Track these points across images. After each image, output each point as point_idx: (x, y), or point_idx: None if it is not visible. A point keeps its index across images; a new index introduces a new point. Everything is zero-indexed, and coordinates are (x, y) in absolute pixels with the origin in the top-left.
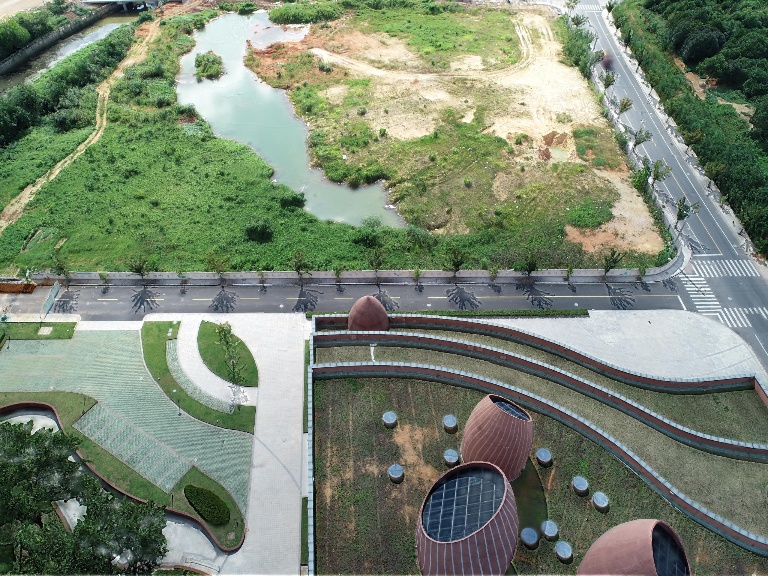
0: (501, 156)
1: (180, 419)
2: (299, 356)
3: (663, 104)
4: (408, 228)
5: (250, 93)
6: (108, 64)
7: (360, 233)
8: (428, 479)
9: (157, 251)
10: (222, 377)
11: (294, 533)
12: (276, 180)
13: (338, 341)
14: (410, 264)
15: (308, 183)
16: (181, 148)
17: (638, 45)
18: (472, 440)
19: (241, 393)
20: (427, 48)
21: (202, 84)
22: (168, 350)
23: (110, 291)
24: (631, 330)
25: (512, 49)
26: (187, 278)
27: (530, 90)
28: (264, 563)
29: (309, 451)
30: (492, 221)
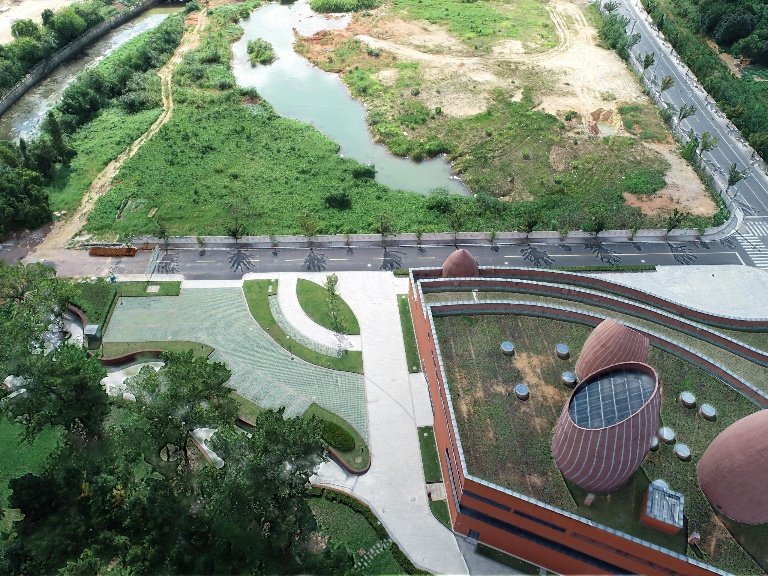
0: (553, 131)
1: (294, 363)
2: (393, 308)
3: (700, 83)
4: (477, 195)
5: (304, 77)
6: (165, 51)
7: (434, 200)
8: (551, 396)
9: (245, 218)
10: (326, 327)
11: (415, 457)
12: (343, 155)
13: (442, 287)
14: (484, 227)
15: (374, 157)
16: (250, 126)
17: (671, 29)
18: (594, 358)
19: (346, 340)
20: (468, 34)
21: (256, 69)
22: (271, 304)
23: (207, 254)
24: (697, 282)
25: (550, 34)
26: (277, 242)
27: (572, 71)
28: (392, 482)
29: (442, 374)
30: (554, 189)
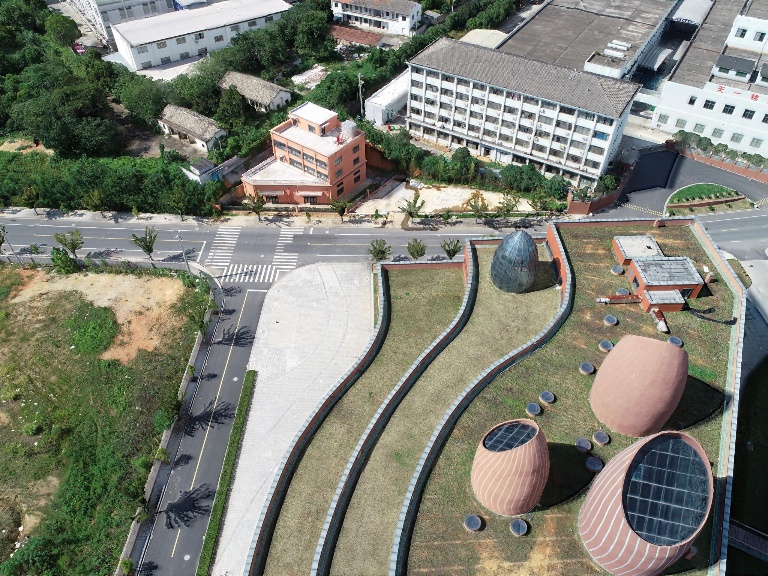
0: None
1: None
2: None
3: None
4: (7, 573)
5: None
6: None
7: None
8: (548, 558)
9: None
10: None
11: None
12: None
13: None
14: None
15: None
16: None
17: None
18: (533, 488)
19: None
20: None
21: None
22: None
23: None
24: (284, 340)
25: None
26: None
27: None
28: None
29: None
30: (50, 441)
